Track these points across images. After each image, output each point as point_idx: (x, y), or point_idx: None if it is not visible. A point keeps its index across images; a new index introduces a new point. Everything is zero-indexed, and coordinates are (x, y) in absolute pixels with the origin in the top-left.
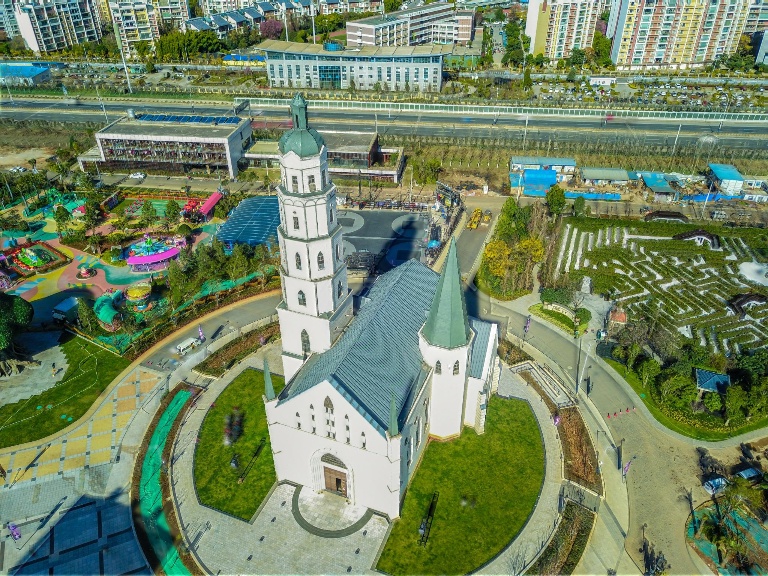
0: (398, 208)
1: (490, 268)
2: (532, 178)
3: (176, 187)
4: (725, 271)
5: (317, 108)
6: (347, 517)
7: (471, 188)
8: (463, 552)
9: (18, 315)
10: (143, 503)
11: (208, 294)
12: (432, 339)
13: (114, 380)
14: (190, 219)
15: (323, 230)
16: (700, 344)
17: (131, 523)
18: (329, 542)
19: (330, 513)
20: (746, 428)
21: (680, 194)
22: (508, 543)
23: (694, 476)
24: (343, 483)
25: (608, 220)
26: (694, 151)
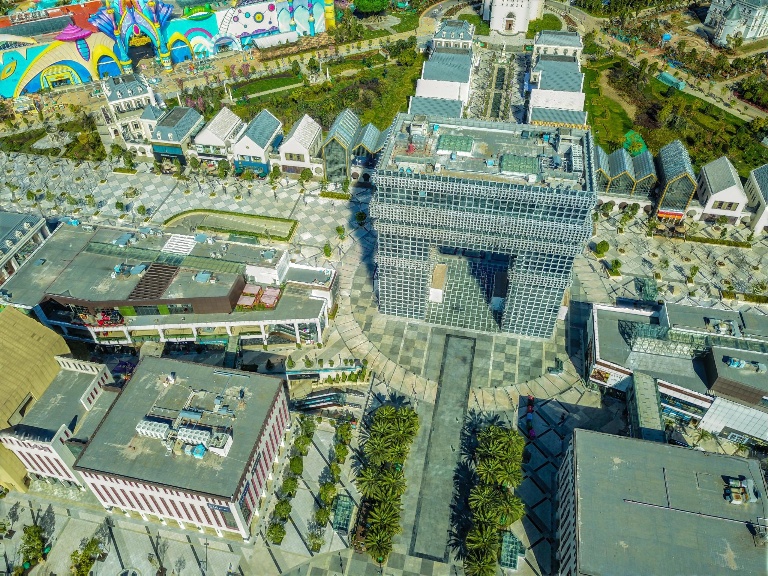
0: None
1: None
2: None
3: None
4: None
5: None
6: None
7: None
8: None
9: None
10: None
11: (428, 0)
12: None
13: None
14: None
15: None
16: None
17: None
18: None
19: None
20: None
21: None
22: None
23: None
24: (511, 25)
25: None
26: None
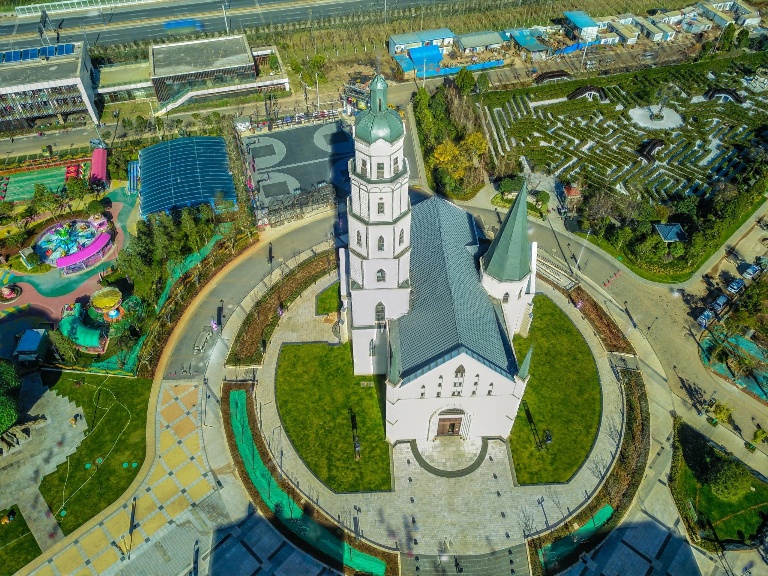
0: (309, 121)
1: (449, 172)
2: (419, 58)
3: (32, 150)
4: (622, 122)
5: (129, 5)
6: (470, 452)
7: (365, 81)
8: (572, 442)
9: (8, 378)
10: (280, 515)
11: (179, 277)
12: (502, 276)
13: (149, 406)
14: (86, 190)
15: (404, 207)
16: (637, 198)
17: (282, 538)
18: (468, 479)
19: (454, 454)
20: (700, 262)
21: (551, 49)
22: (599, 421)
23: (686, 315)
24: (457, 425)
25: (509, 91)
26: (546, 0)
